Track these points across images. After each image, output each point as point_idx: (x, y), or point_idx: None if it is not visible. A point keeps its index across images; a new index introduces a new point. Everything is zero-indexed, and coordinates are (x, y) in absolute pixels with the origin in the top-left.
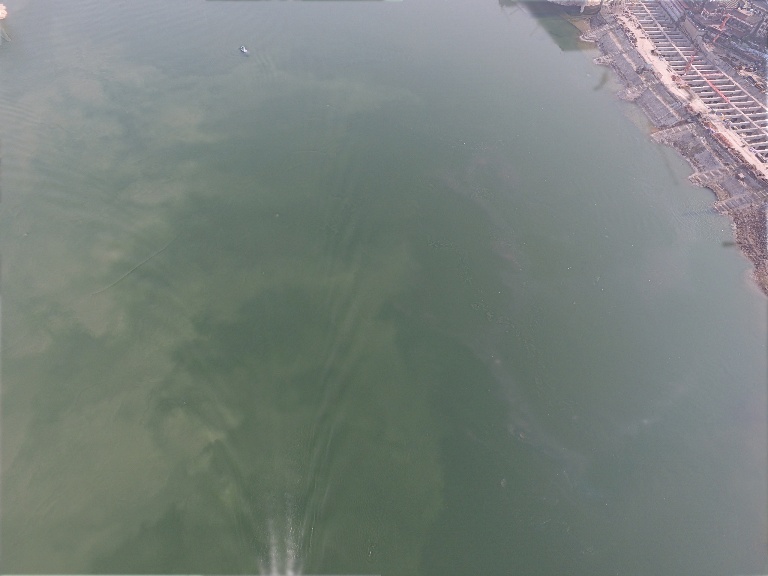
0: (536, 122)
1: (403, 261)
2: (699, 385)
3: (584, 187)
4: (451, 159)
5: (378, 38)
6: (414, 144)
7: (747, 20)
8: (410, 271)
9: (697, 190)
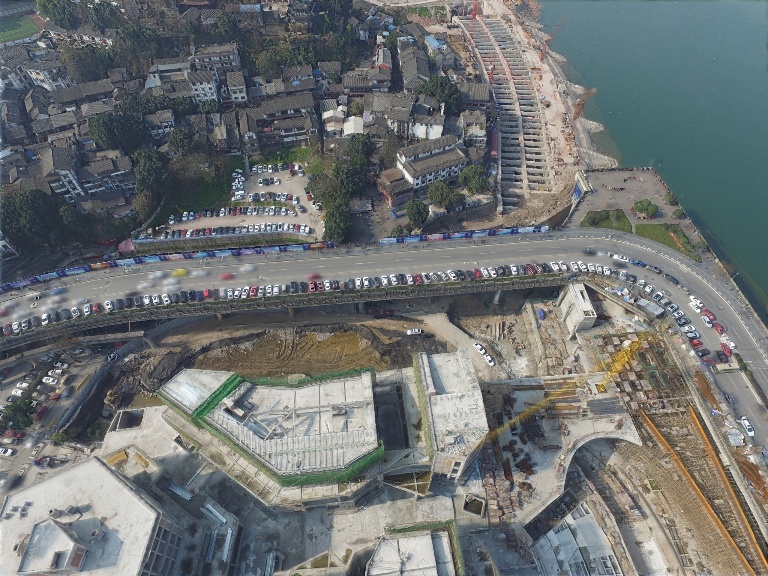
0: (659, 74)
1: None
2: None
3: (621, 37)
4: (718, 57)
5: None
6: (755, 57)
7: None
8: None
9: None
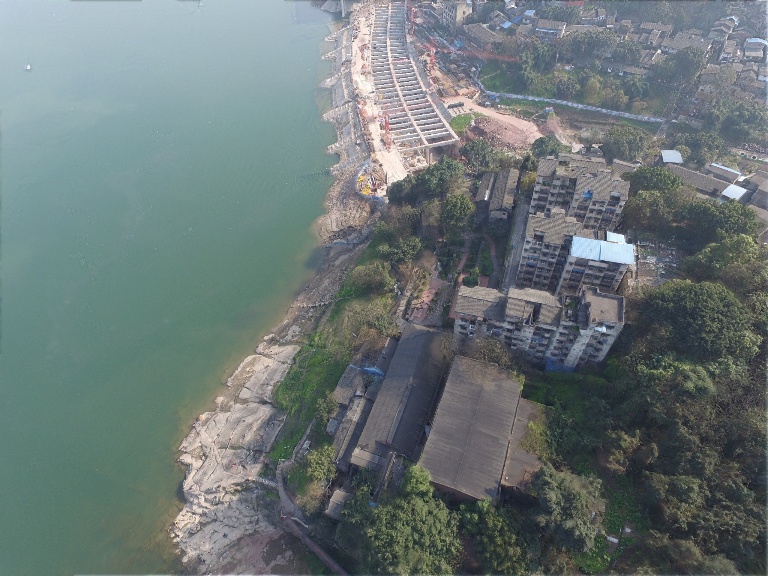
0: (234, 111)
1: (45, 226)
2: (209, 303)
3: (234, 160)
4: None
5: (148, 50)
6: (112, 134)
7: (435, 12)
8: (46, 233)
9: (329, 156)
